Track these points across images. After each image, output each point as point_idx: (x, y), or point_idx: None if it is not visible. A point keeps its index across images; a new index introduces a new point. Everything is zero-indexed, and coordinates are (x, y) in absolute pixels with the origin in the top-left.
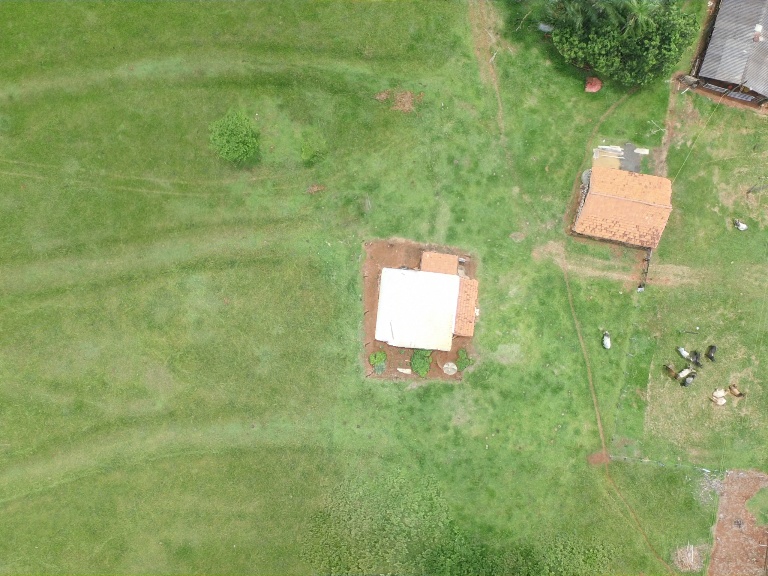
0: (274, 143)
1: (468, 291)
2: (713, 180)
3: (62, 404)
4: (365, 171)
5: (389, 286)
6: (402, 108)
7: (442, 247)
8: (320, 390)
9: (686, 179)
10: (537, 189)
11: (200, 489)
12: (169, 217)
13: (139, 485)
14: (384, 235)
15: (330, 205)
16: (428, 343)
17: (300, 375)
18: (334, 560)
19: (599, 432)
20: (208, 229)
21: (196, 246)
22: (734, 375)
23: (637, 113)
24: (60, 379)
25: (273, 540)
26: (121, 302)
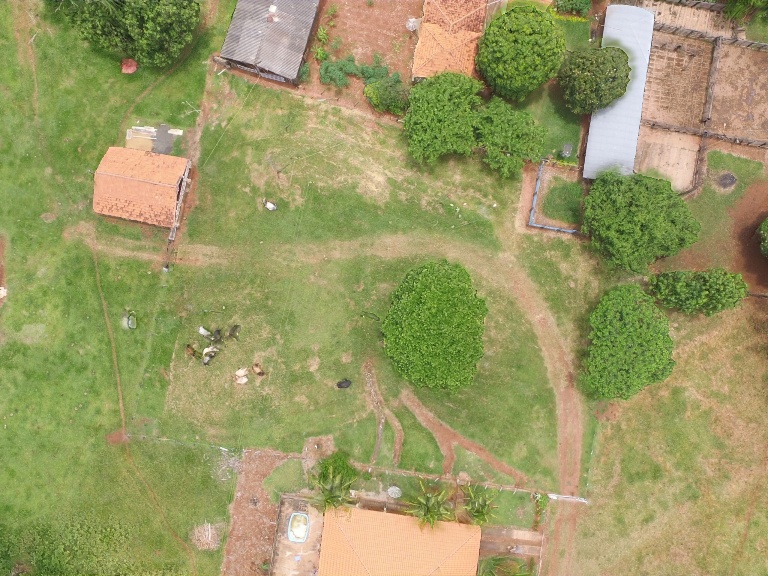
0: None
1: None
2: (246, 160)
3: None
4: None
5: None
6: None
7: None
8: None
9: (219, 160)
10: (69, 170)
11: None
12: None
13: None
14: None
15: None
16: None
17: None
18: None
19: (120, 411)
20: None
21: None
22: (258, 354)
23: (174, 94)
24: None
25: None
26: None
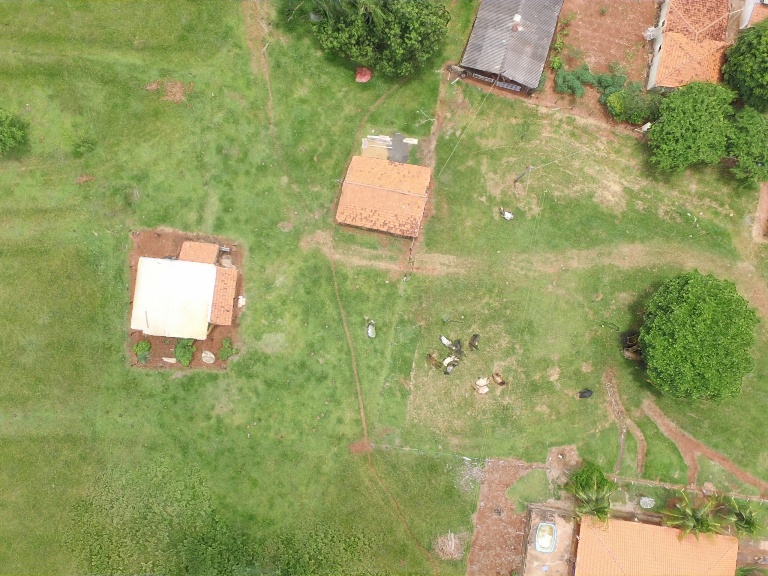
0: (44, 133)
1: (225, 280)
2: (481, 170)
3: None
4: (134, 161)
5: (146, 275)
6: (173, 98)
7: (209, 237)
8: (85, 379)
9: (454, 169)
10: (305, 179)
11: None
12: None
13: None
14: (151, 225)
15: (98, 195)
16: (183, 332)
17: (65, 364)
18: (95, 549)
19: (362, 421)
20: None
21: None
22: (498, 364)
23: (407, 103)
24: None
25: (35, 529)
26: None
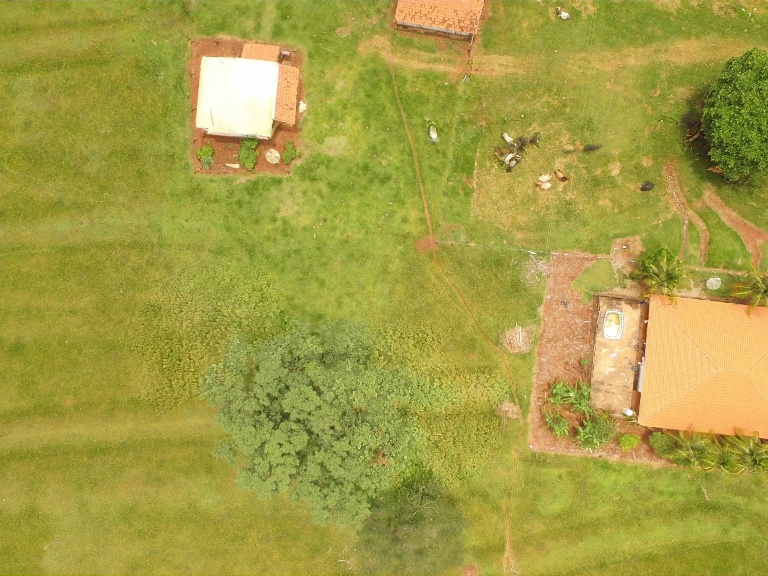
0: None
1: (288, 78)
2: None
3: None
4: None
5: (209, 74)
6: None
7: None
8: (149, 187)
9: None
10: None
11: (31, 287)
12: None
13: None
14: (210, 33)
15: (156, 6)
16: (248, 128)
17: (129, 173)
18: (165, 352)
19: (426, 219)
20: (34, 32)
21: (22, 48)
22: (559, 160)
23: None
24: None
25: (104, 334)
26: None
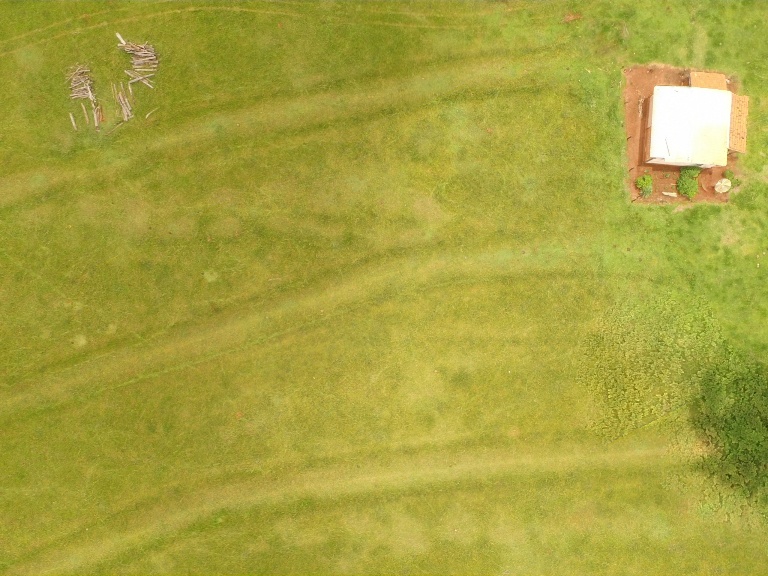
0: None
1: (740, 107)
2: None
3: (331, 237)
4: None
5: (662, 104)
6: None
7: (701, 71)
8: (587, 216)
9: None
10: None
11: (473, 317)
12: (427, 50)
13: (412, 314)
14: (643, 61)
15: (587, 33)
16: (704, 158)
17: (566, 202)
18: (610, 382)
19: None
20: (466, 61)
21: (457, 77)
22: None
23: None
24: (328, 212)
25: (548, 364)
26: (385, 135)
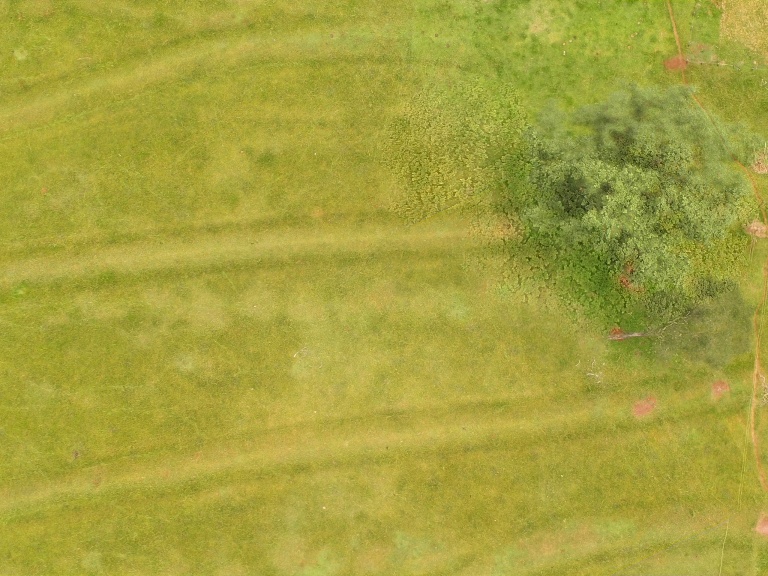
0: None
1: None
2: None
3: (142, 18)
4: None
5: None
6: None
7: None
8: (397, 3)
9: None
10: None
11: (280, 99)
12: None
13: (220, 96)
14: None
15: None
16: None
17: None
18: (414, 165)
19: (675, 39)
20: None
21: None
22: None
23: None
24: None
25: (353, 147)
26: None
